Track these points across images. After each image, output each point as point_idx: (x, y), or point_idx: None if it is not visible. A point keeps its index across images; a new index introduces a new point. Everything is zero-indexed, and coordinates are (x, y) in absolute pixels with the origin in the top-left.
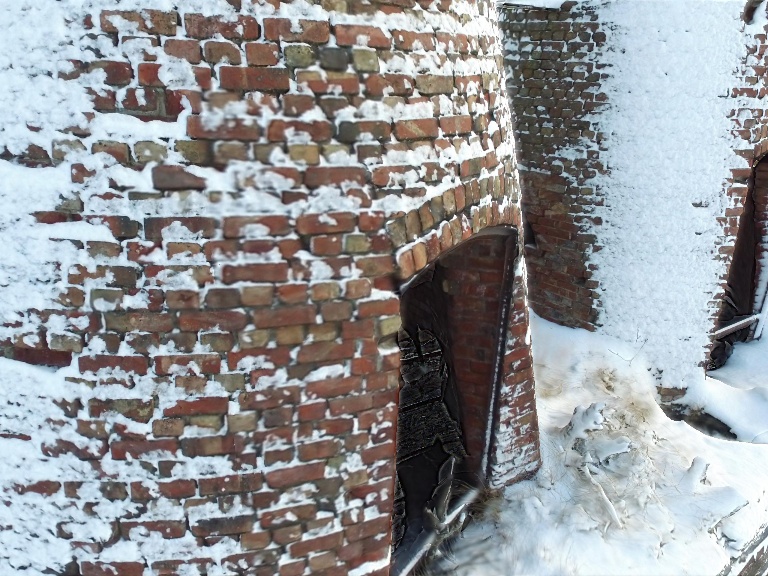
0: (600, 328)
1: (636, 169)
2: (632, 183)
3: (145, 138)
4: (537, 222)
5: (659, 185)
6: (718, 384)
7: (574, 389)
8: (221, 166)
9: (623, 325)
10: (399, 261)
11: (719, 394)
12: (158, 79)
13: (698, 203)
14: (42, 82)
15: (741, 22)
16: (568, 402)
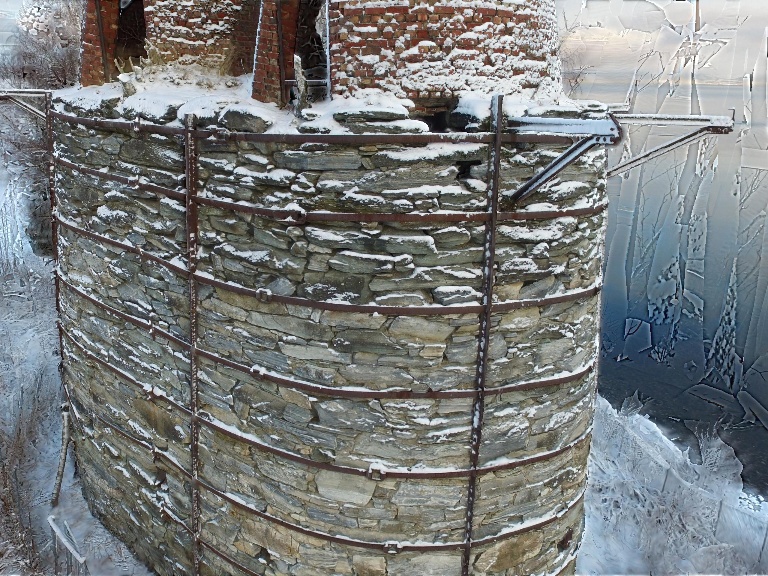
0: None
1: None
2: None
3: None
4: (301, 8)
5: None
6: None
7: None
8: None
9: None
10: None
11: None
12: None
13: None
14: None
15: None
16: (201, 75)
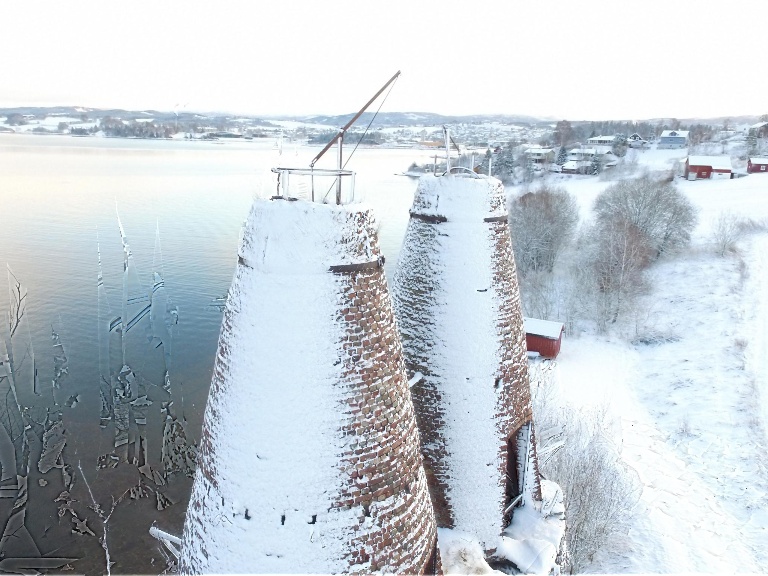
0: (455, 527)
1: (462, 453)
2: (461, 459)
3: (362, 569)
4: None
5: (472, 459)
6: (509, 541)
7: (451, 567)
8: (379, 569)
9: (465, 524)
10: (419, 575)
11: (510, 548)
12: (365, 553)
13: (489, 464)
14: (337, 562)
15: (494, 389)
16: None
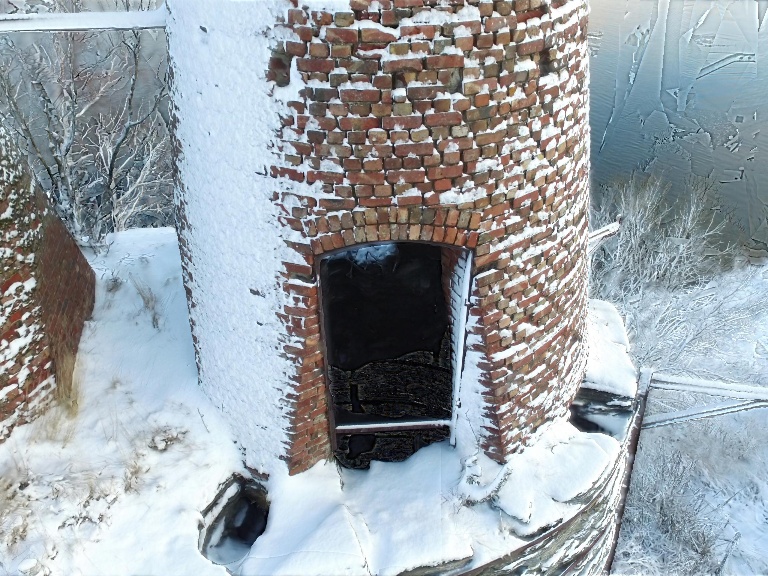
0: (201, 383)
1: (203, 234)
2: (203, 248)
3: None
4: None
5: (219, 259)
6: (312, 483)
7: (105, 439)
8: None
9: (212, 389)
10: None
11: (294, 495)
12: None
13: (256, 290)
14: None
15: (267, 83)
16: (67, 451)
